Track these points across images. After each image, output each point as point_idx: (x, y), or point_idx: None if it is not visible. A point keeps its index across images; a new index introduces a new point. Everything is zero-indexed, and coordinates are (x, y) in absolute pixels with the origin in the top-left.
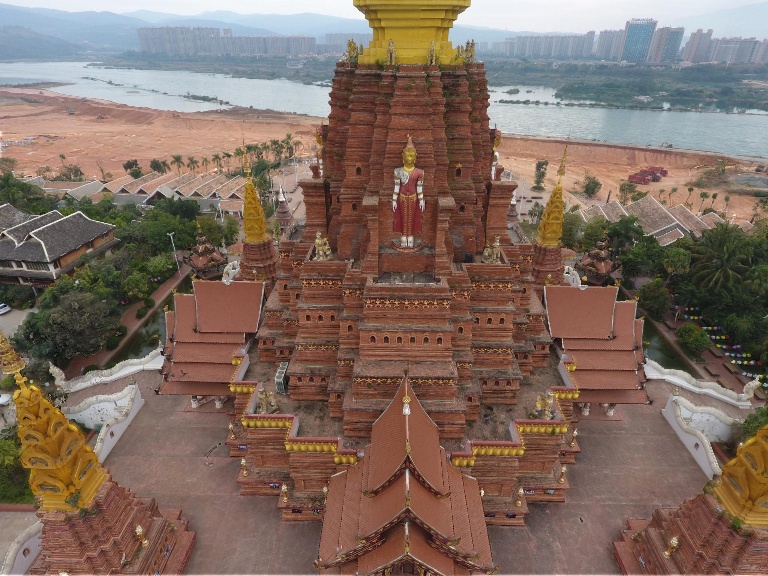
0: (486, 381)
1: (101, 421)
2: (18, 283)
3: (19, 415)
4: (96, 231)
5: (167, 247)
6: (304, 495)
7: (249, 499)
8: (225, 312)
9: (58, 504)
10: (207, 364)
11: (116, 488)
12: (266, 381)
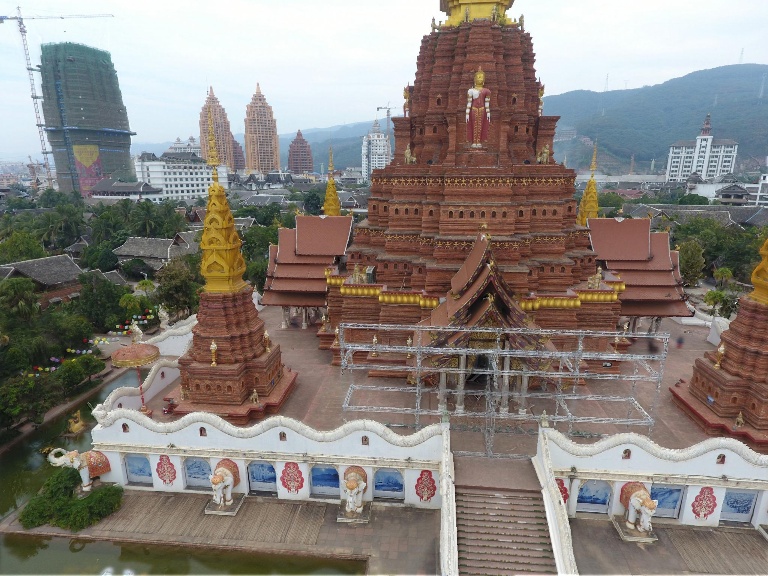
0: None
1: None
2: None
3: None
4: None
5: None
6: None
7: None
8: None
9: None
10: None
11: None
12: None
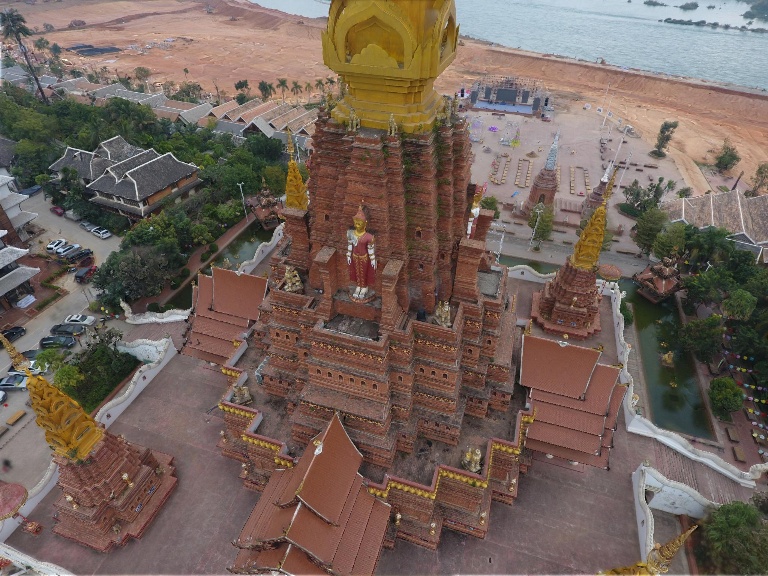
0: (427, 421)
1: (148, 358)
2: (118, 213)
3: (30, 395)
4: (181, 172)
5: (239, 193)
6: (262, 472)
7: (226, 460)
8: (235, 298)
9: (64, 452)
10: (218, 338)
11: (113, 442)
12: (254, 368)
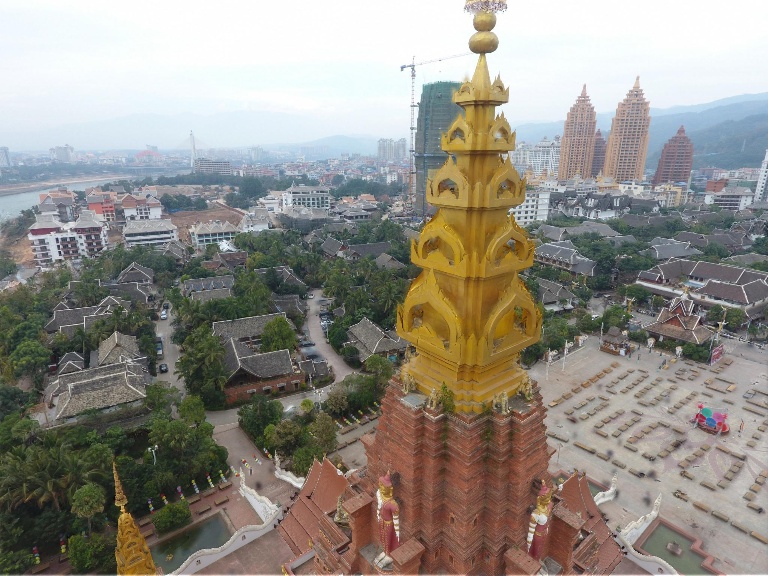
0: None
1: None
2: None
3: None
4: None
5: None
6: None
7: None
8: None
9: None
10: None
11: None
12: None
